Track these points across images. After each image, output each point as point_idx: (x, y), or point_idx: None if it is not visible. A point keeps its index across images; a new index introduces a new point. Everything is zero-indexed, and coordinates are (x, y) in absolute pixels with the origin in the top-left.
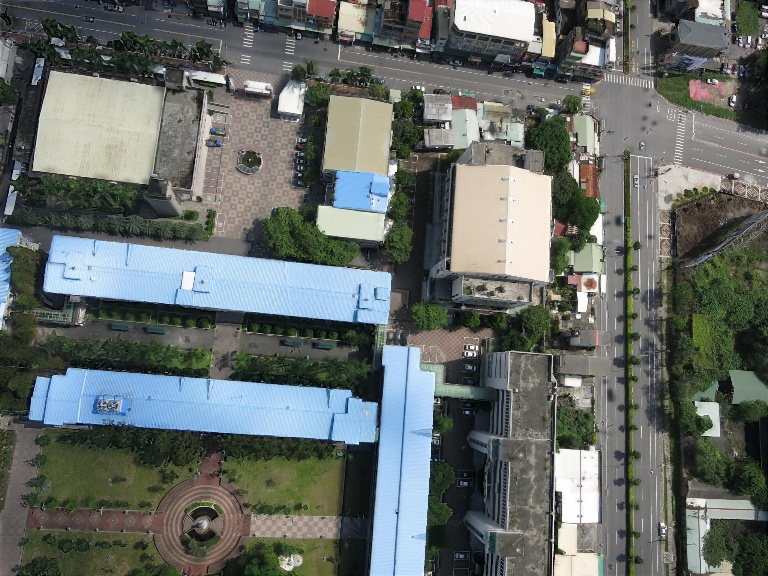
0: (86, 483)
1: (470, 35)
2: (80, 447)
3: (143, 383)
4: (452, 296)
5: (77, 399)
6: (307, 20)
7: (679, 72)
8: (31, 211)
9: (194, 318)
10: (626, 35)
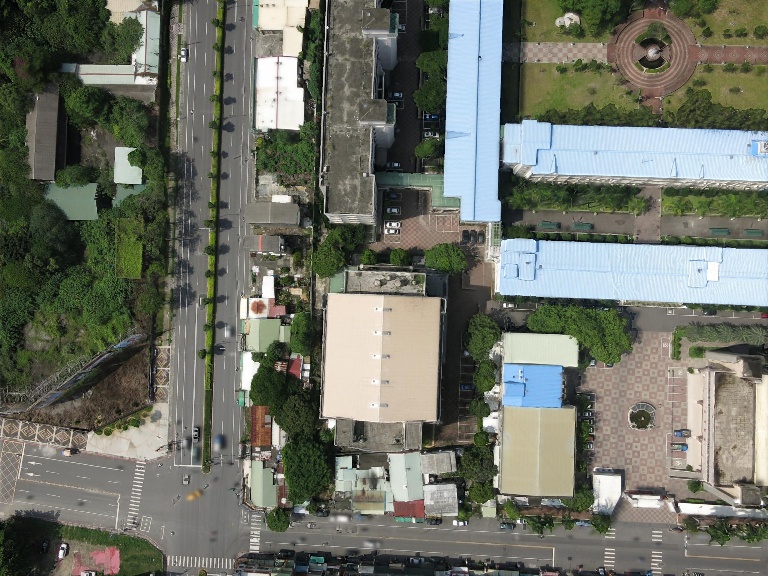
0: (763, 88)
1: None
2: None
3: (740, 170)
4: None
5: None
6: None
7: None
8: None
9: None
10: None
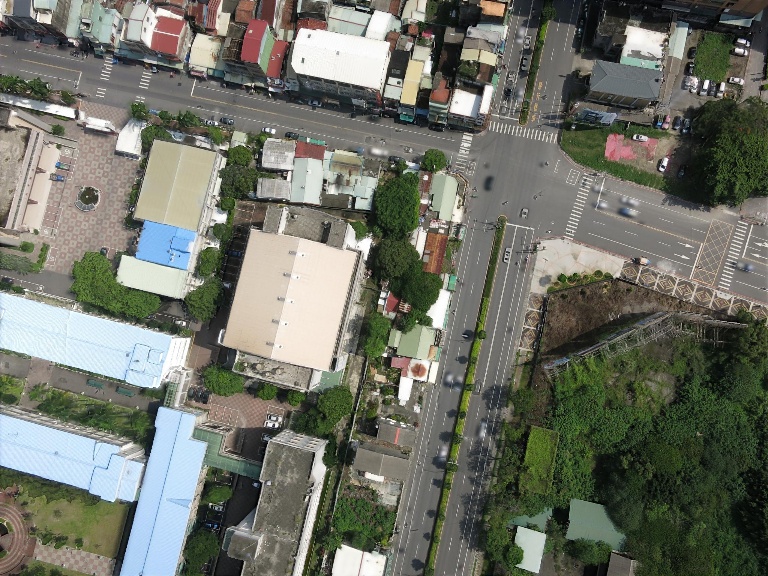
0: None
1: (314, 78)
2: None
3: None
4: None
5: None
6: (156, 55)
7: (593, 124)
8: None
9: None
10: (531, 75)
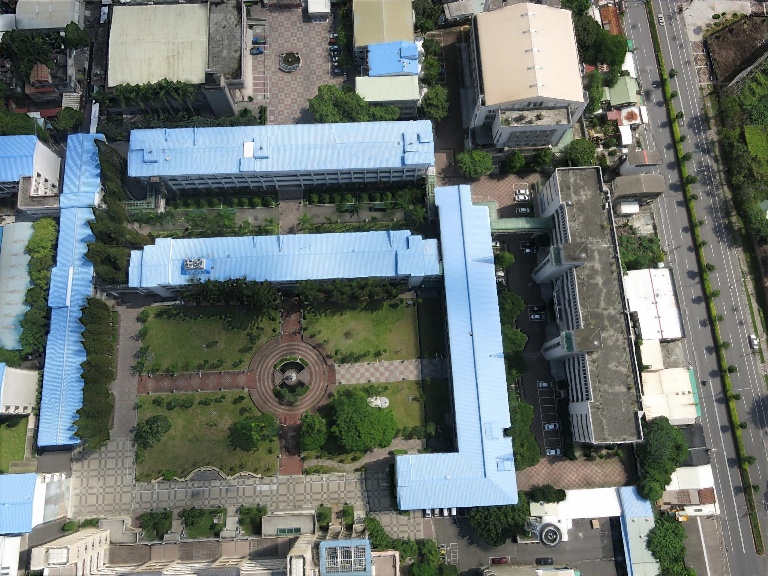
0: (184, 351)
1: None
2: (175, 320)
3: (221, 243)
4: (493, 139)
5: (167, 262)
6: None
7: None
8: (111, 125)
9: (259, 197)
10: None
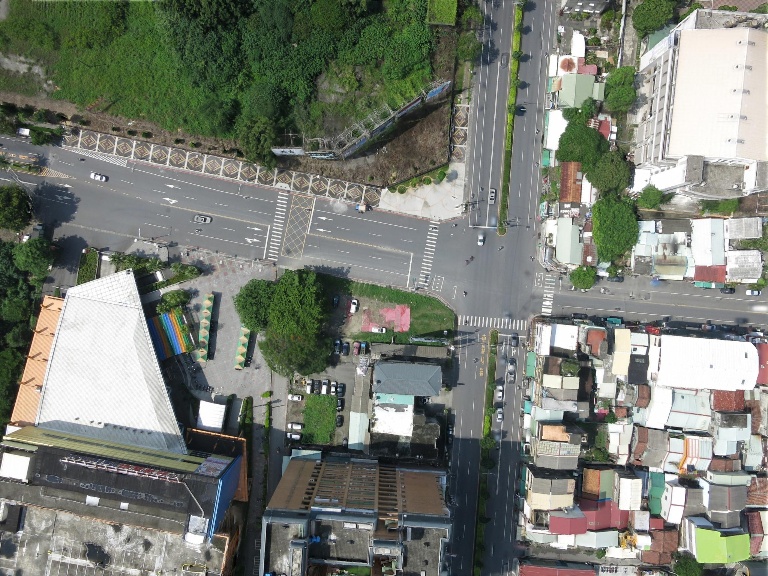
0: None
1: None
2: None
3: None
4: None
5: None
6: None
7: None
8: None
9: None
10: (492, 381)
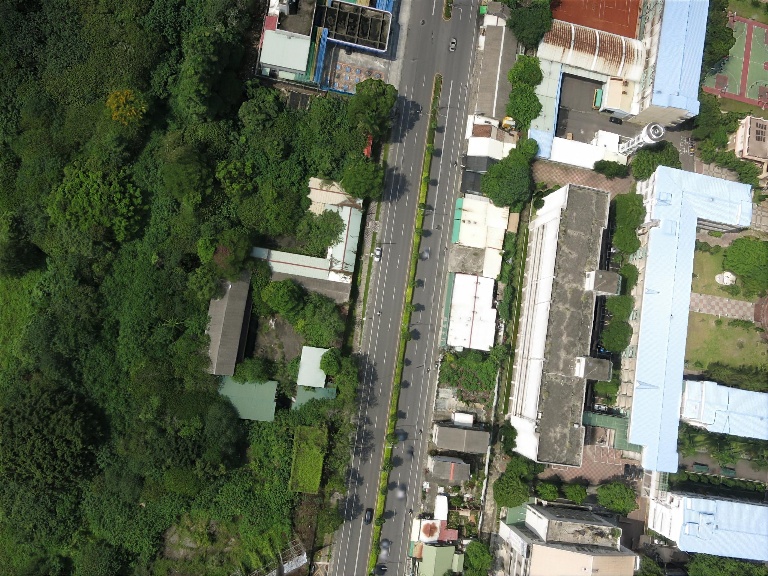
0: None
1: None
2: None
3: None
4: None
5: None
6: None
7: None
8: None
9: None
10: None
